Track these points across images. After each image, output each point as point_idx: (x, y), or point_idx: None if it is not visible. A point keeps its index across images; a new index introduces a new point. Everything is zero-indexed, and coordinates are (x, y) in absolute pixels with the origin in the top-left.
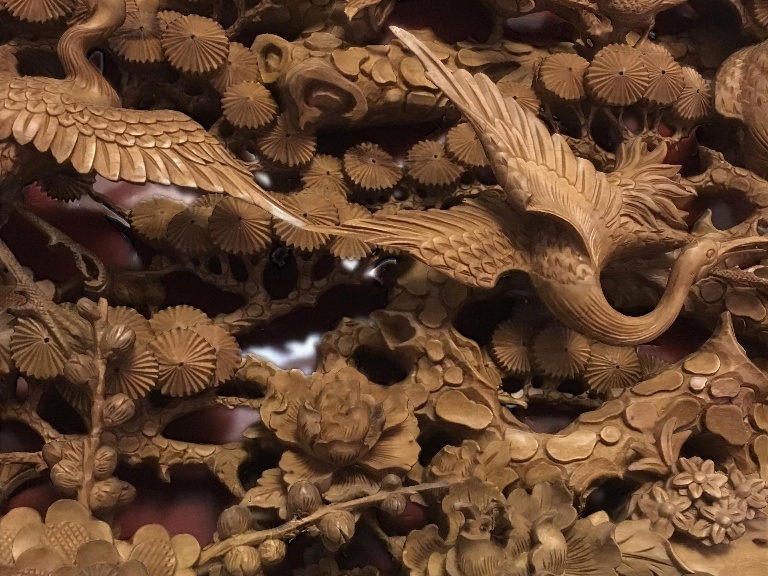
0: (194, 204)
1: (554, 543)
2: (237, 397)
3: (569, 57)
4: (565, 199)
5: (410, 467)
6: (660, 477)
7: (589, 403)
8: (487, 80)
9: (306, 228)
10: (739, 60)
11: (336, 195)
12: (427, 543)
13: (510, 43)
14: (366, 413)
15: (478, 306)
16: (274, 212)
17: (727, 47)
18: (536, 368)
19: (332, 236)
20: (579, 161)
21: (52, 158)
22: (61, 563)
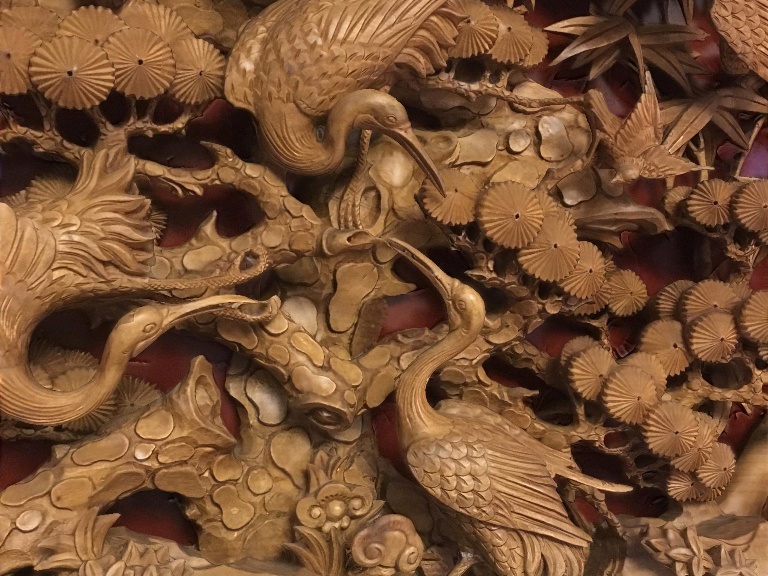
0: None
1: None
2: None
3: (12, 33)
4: None
5: None
6: (75, 570)
7: (54, 437)
8: None
9: None
10: (263, 28)
11: None
12: None
13: None
14: None
15: None
16: None
17: None
18: None
19: None
20: None
21: None
22: None
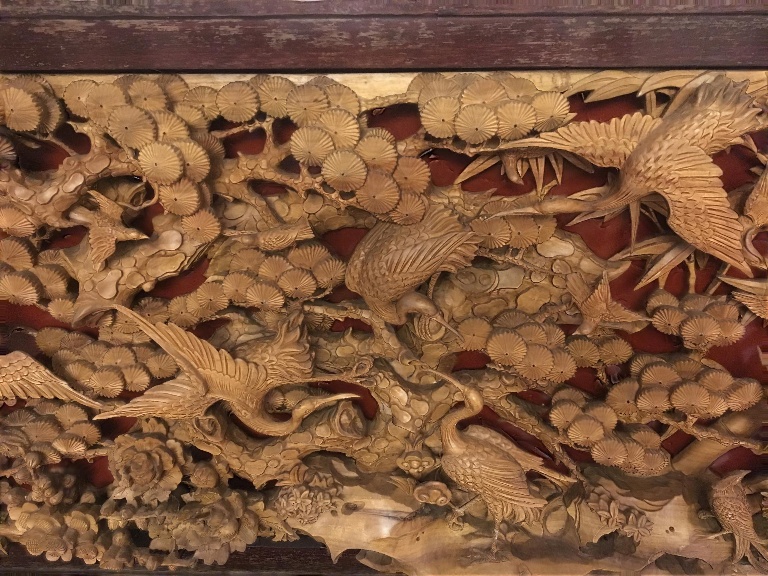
0: (63, 340)
1: (227, 532)
2: (106, 442)
3: (238, 278)
4: (228, 387)
5: (176, 487)
6: None
7: None
8: (175, 327)
9: None
10: (363, 253)
11: (126, 352)
12: None
13: (230, 207)
14: None
15: None
16: (82, 403)
17: None
18: None
19: (121, 391)
20: (237, 362)
21: None
22: (43, 534)
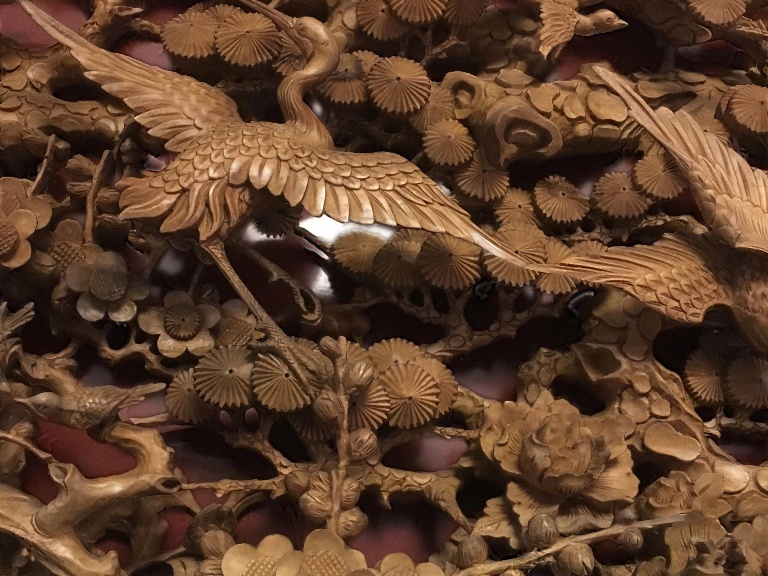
0: (394, 238)
1: None
2: (454, 428)
3: (759, 90)
4: None
5: (632, 499)
6: None
7: None
8: (688, 117)
9: (528, 267)
10: None
11: (535, 230)
12: (654, 574)
13: (684, 73)
14: (589, 447)
15: (668, 336)
16: (493, 251)
17: None
18: (729, 398)
19: (541, 272)
20: None
21: (285, 201)
22: None
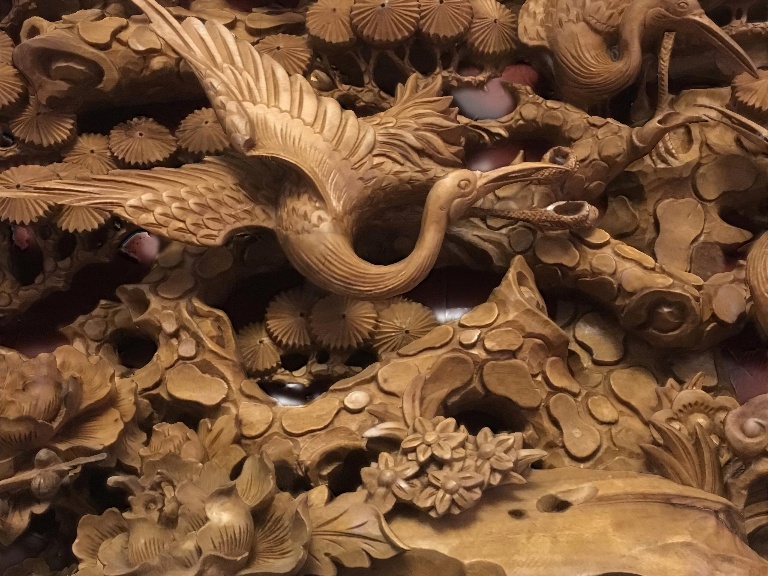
0: None
1: (225, 519)
2: None
3: None
4: (296, 140)
5: (102, 446)
6: None
7: None
8: (218, 25)
9: None
10: None
11: (80, 169)
12: (109, 530)
13: None
14: (52, 389)
15: (257, 279)
16: None
17: None
18: (315, 340)
19: (51, 207)
20: (321, 100)
21: None
22: None
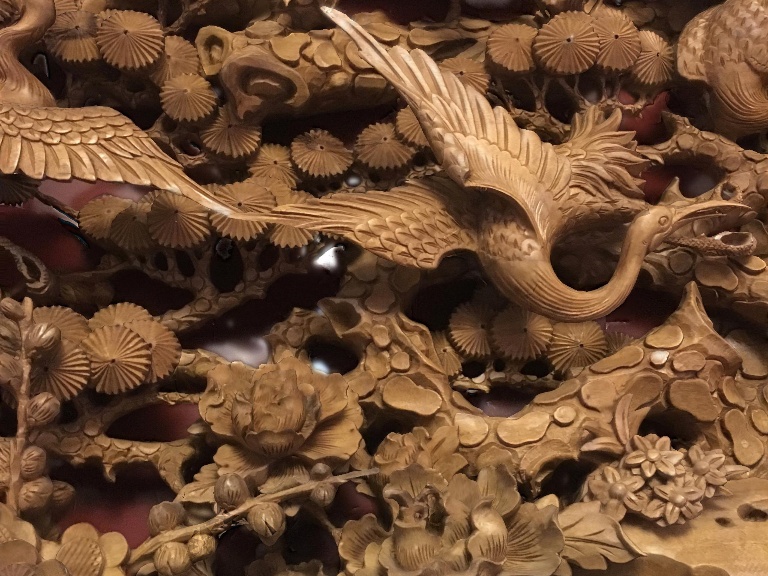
0: (140, 201)
1: (491, 529)
2: (178, 393)
3: (517, 28)
4: (507, 172)
5: (349, 456)
6: (616, 457)
7: (554, 385)
8: (424, 55)
9: (232, 216)
10: (702, 20)
11: (279, 183)
12: (366, 534)
13: (467, 20)
14: (301, 402)
15: (435, 290)
16: (203, 202)
17: (695, 8)
18: (496, 351)
19: (269, 224)
20: (523, 133)
21: None
22: None
